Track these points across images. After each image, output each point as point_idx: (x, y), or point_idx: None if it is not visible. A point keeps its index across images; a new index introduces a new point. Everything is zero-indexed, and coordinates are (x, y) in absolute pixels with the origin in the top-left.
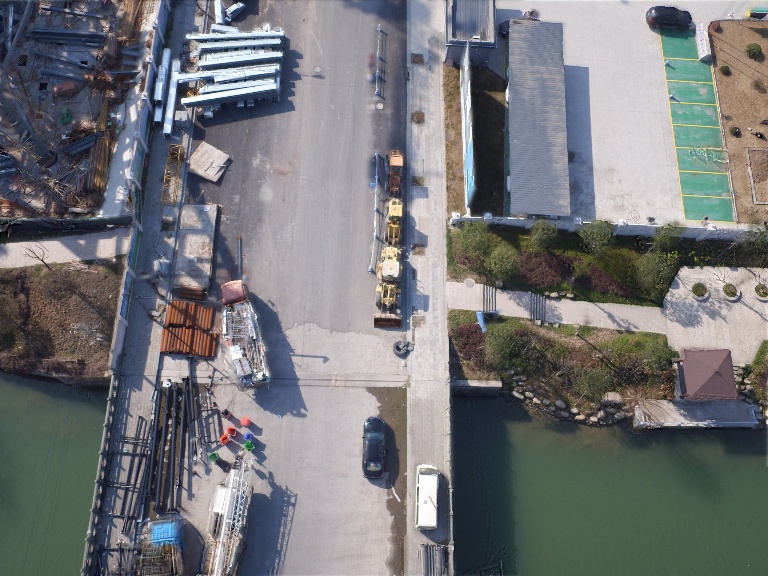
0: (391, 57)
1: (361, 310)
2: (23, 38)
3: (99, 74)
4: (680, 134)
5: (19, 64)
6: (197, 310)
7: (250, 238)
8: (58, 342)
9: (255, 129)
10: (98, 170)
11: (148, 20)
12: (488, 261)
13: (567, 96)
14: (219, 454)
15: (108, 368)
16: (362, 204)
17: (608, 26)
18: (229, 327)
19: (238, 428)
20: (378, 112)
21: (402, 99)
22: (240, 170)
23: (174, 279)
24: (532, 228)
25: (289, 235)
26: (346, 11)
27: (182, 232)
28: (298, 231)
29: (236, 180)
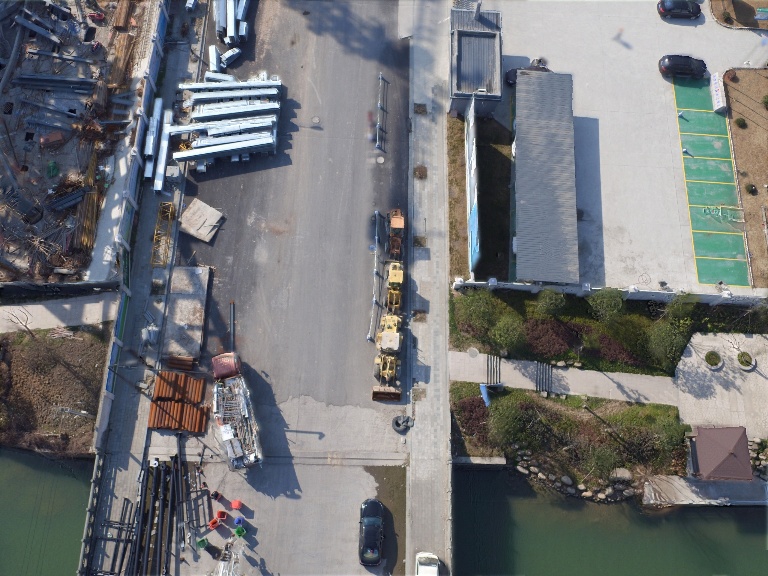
0: (393, 107)
1: (359, 382)
2: (9, 84)
3: (88, 123)
4: (694, 191)
5: (4, 112)
6: (187, 382)
7: (243, 303)
8: (41, 415)
9: (250, 184)
10: (85, 228)
11: (140, 66)
12: (492, 330)
13: (576, 150)
14: (208, 539)
15: (93, 445)
16: (361, 266)
17: (619, 74)
18: (220, 405)
19: (229, 510)
20: (379, 166)
21: (404, 152)
22: (234, 229)
23: (163, 348)
24: (539, 293)
25: (284, 300)
26: (346, 57)
27: (172, 296)
28: (294, 295)
29: (229, 240)
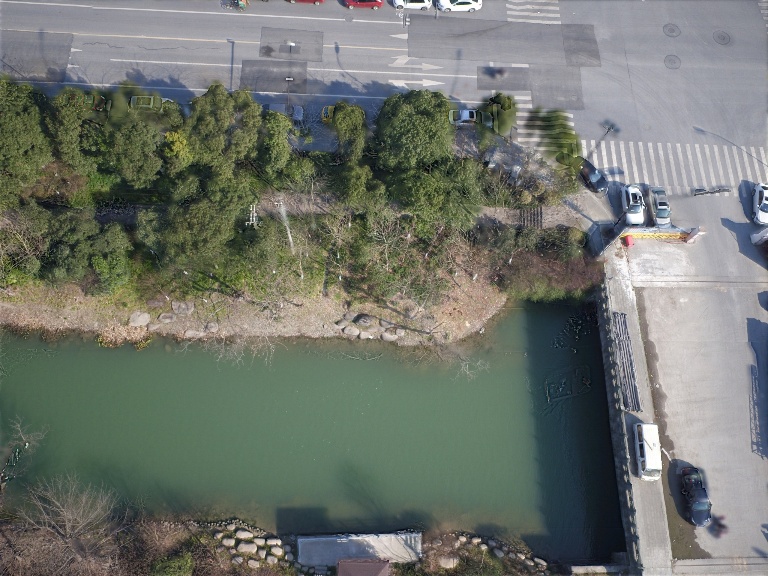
0: None
1: None
2: None
3: None
4: None
5: None
6: None
7: None
8: None
9: None
10: None
11: None
12: None
13: None
14: None
15: None
16: None
17: None
18: None
19: None
20: None
21: None
22: None
23: None
24: None
25: None
26: None
27: None
28: None
29: None
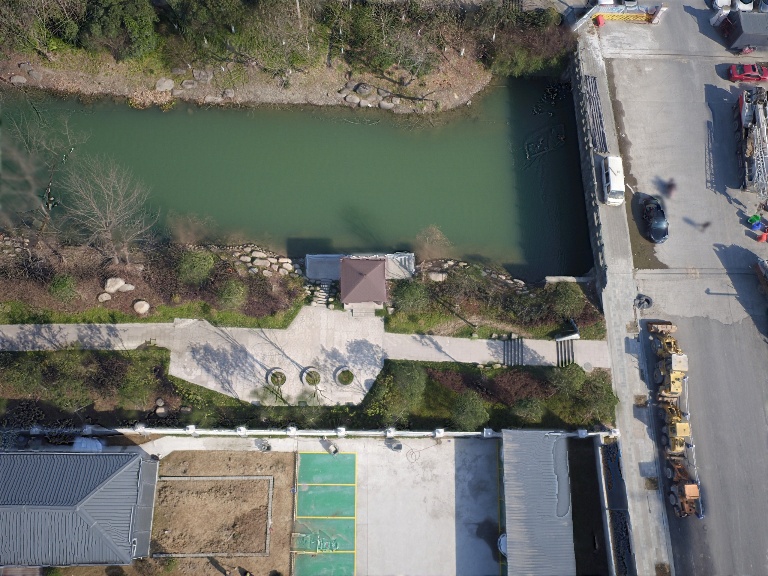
0: None
1: (685, 338)
2: None
3: None
4: (347, 572)
5: None
6: None
7: None
8: None
9: None
10: None
11: None
12: None
13: None
14: None
15: None
16: (705, 453)
17: None
18: None
19: None
20: None
21: None
22: None
23: None
24: None
25: None
26: None
27: None
28: (761, 418)
29: None
